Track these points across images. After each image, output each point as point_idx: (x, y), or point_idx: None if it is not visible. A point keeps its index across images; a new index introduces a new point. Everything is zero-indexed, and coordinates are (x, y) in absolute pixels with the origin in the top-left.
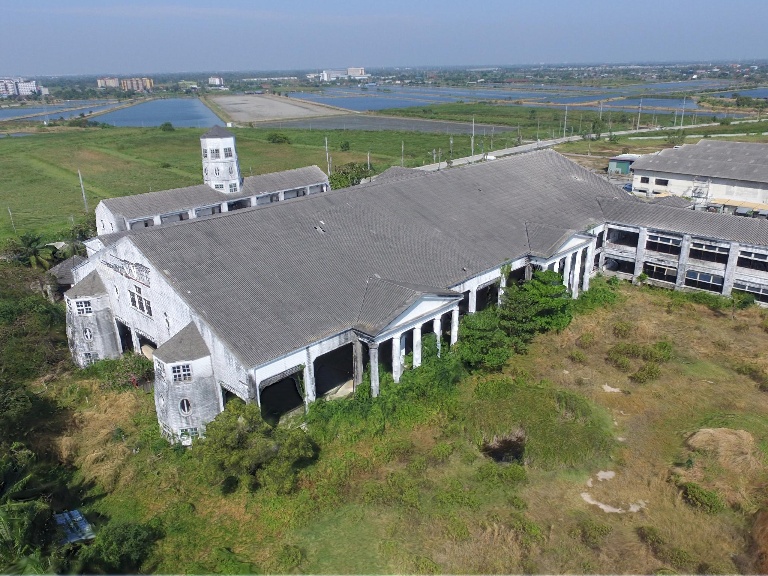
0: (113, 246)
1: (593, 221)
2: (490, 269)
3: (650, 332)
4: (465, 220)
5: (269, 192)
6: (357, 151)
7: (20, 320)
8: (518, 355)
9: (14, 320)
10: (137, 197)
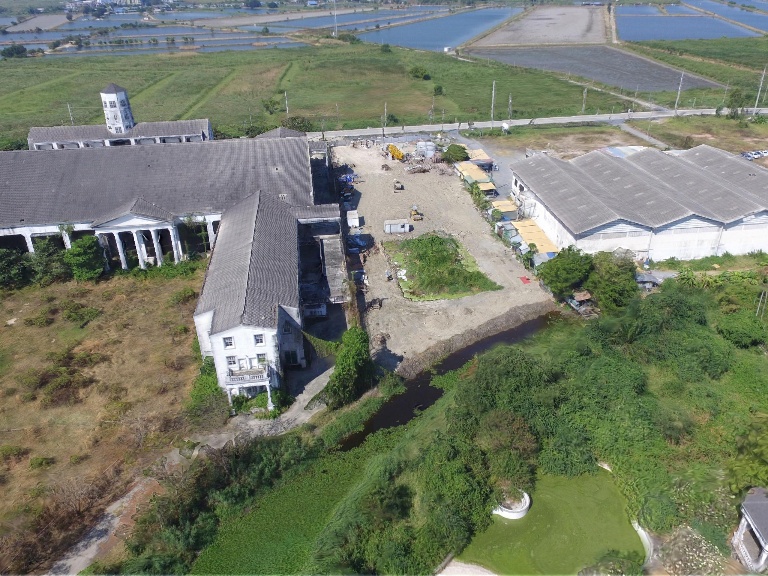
0: None
1: (207, 210)
2: (42, 224)
3: (122, 303)
4: (90, 187)
5: (146, 136)
6: (446, 97)
7: None
8: (39, 286)
9: None
10: (53, 128)
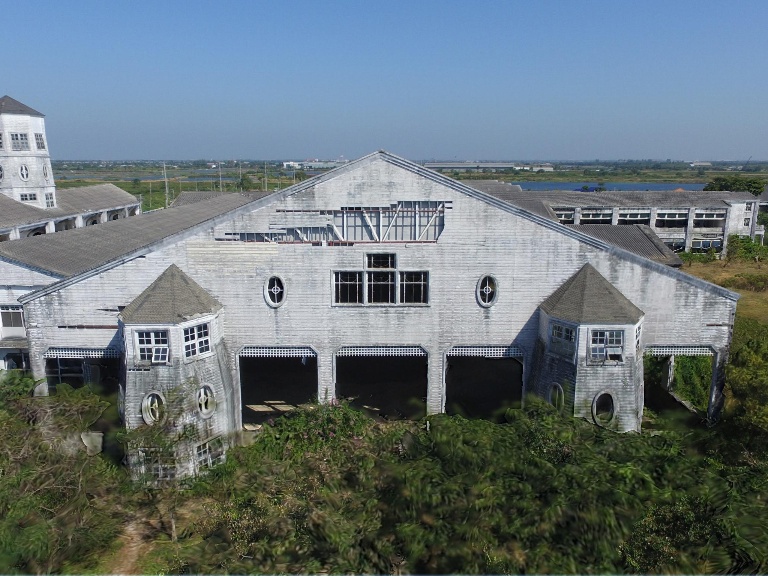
0: (303, 186)
1: None
2: None
3: None
4: None
5: (93, 210)
6: None
7: (41, 406)
8: None
9: (2, 417)
10: None
